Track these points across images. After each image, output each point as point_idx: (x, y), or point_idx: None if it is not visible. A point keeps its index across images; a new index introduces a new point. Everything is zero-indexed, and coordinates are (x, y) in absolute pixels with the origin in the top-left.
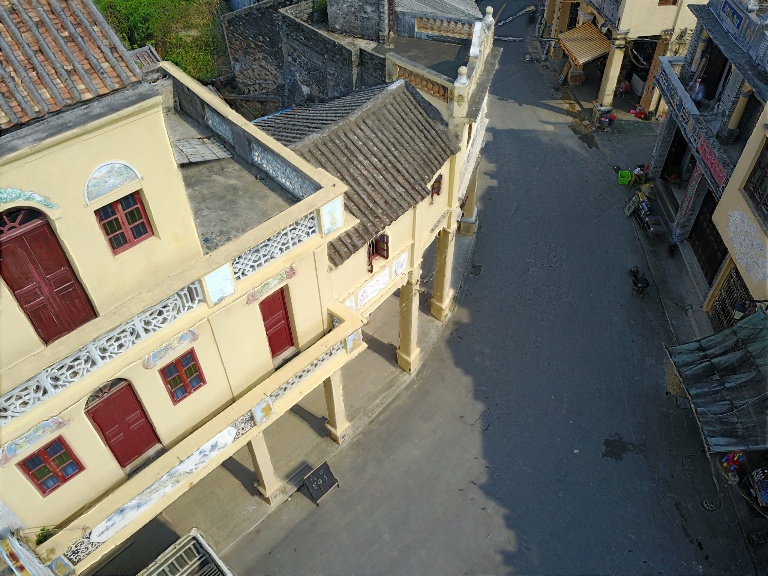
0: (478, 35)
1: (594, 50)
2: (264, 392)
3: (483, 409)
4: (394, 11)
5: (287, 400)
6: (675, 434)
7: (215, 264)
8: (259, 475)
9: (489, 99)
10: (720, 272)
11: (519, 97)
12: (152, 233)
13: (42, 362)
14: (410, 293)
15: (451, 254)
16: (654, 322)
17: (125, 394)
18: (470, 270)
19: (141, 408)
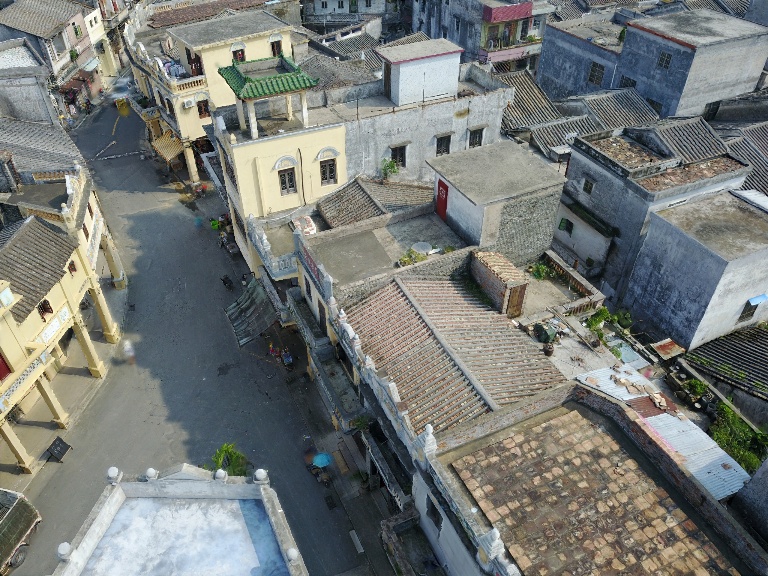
0: (69, 182)
1: (175, 150)
2: (0, 393)
3: (150, 379)
4: (16, 172)
5: (16, 396)
6: (253, 352)
7: None
8: (17, 454)
9: (120, 194)
10: None
11: (141, 188)
12: None
13: None
14: (79, 329)
15: (103, 302)
16: None
17: None
18: (128, 309)
19: None
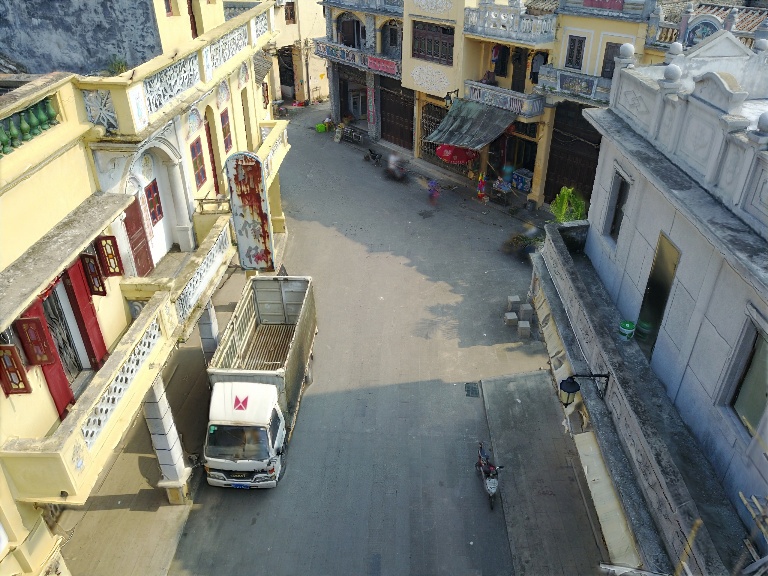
0: None
1: None
2: (269, 146)
3: (344, 228)
4: None
5: (274, 166)
6: (447, 200)
7: (254, 13)
8: None
9: None
10: (415, 127)
11: None
12: (209, 2)
13: (224, 28)
14: None
15: None
16: (397, 172)
17: None
18: None
19: (212, 152)
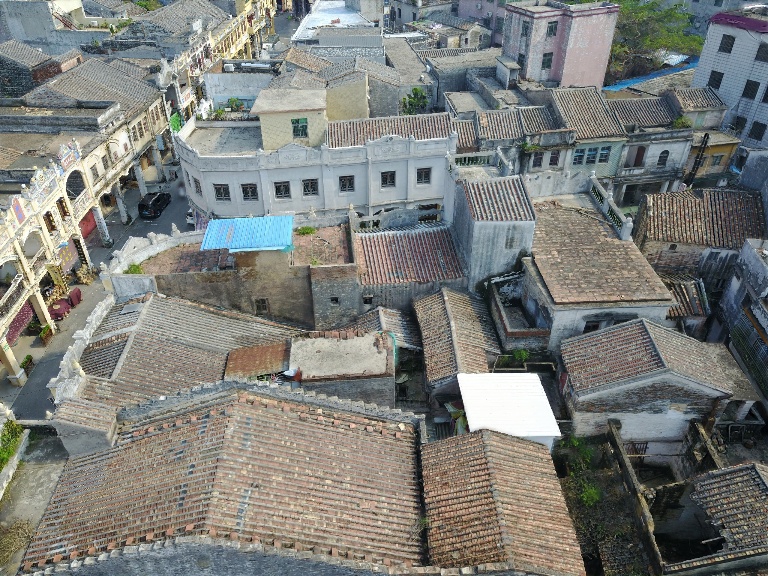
0: None
1: None
2: None
3: None
4: None
5: None
6: None
7: None
8: None
9: None
10: None
11: None
12: None
13: None
14: None
15: None
16: None
17: (261, 6)
18: None
19: None
